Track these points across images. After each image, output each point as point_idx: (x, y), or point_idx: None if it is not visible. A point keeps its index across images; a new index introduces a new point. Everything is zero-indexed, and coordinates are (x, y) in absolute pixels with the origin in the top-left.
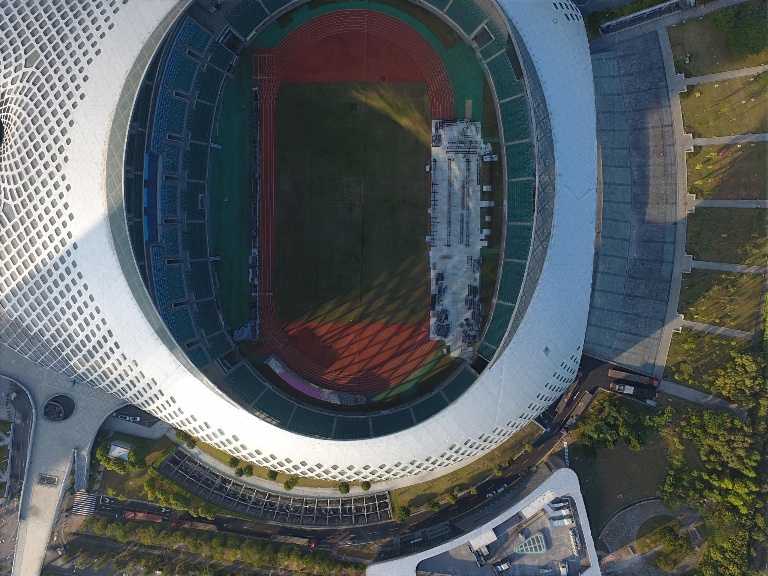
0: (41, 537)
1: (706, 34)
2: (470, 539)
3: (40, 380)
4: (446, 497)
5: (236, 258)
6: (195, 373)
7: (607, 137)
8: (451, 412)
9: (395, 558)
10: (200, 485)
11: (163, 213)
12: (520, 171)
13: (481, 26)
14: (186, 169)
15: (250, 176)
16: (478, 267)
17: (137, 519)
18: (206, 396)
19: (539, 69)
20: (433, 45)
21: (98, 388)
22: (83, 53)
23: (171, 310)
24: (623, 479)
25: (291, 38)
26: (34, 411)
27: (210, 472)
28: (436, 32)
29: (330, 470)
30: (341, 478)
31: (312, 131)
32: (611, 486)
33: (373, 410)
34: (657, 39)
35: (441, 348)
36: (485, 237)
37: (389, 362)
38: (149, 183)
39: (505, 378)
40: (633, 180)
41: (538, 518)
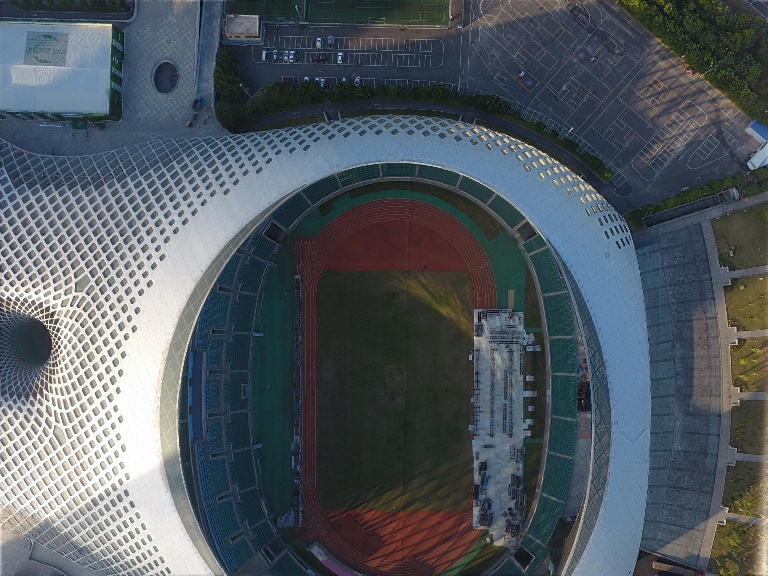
0: None
1: (750, 227)
2: None
3: (84, 569)
4: None
5: (278, 444)
6: None
7: (652, 333)
8: None
9: None
10: None
11: (207, 408)
12: (564, 366)
13: (525, 222)
14: (229, 361)
15: (292, 363)
16: (521, 457)
17: None
18: None
19: (594, 315)
20: (475, 235)
21: None
22: (134, 282)
23: (216, 505)
24: None
25: (333, 226)
26: None
27: None
28: (478, 222)
29: None
30: None
31: (354, 319)
32: None
33: None
34: (701, 231)
35: (484, 537)
36: (528, 427)
37: (432, 550)
38: (194, 381)
39: None
40: (677, 372)
41: None
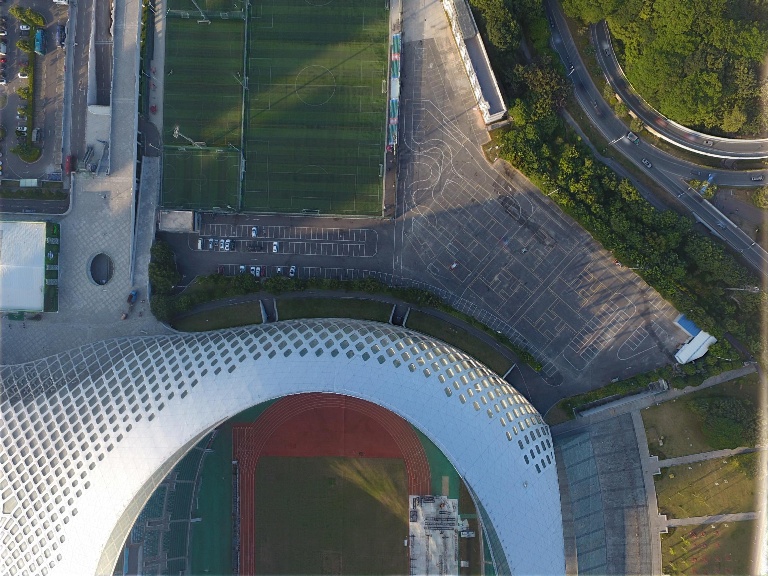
0: None
1: (679, 417)
2: None
3: None
4: None
5: None
6: None
7: (582, 524)
8: None
9: None
10: None
11: None
12: None
13: None
14: (166, 549)
15: (230, 547)
16: None
17: None
18: None
19: (509, 555)
20: None
21: None
22: (60, 509)
23: None
24: None
25: (269, 412)
26: None
27: None
28: None
29: None
30: None
31: (291, 504)
32: None
33: None
34: (631, 421)
35: None
36: None
37: None
38: (129, 575)
39: None
40: (609, 559)
41: None
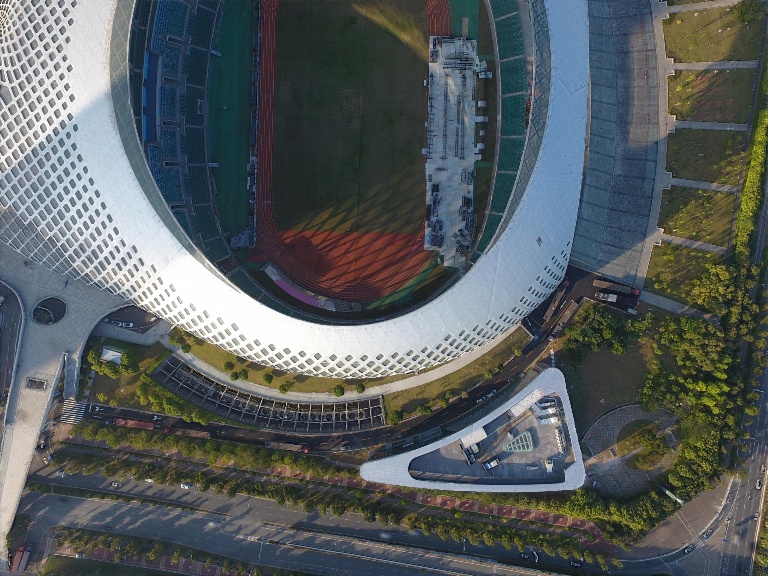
0: (28, 442)
1: None
2: (461, 437)
3: (30, 282)
4: (438, 403)
5: (234, 166)
6: (197, 256)
7: (596, 57)
8: (448, 298)
9: (388, 456)
10: (193, 392)
11: (162, 115)
12: (514, 86)
13: None
14: (186, 73)
15: (250, 85)
16: (472, 180)
17: (128, 427)
18: (207, 280)
19: None
20: None
21: (93, 284)
22: None
23: None
24: (605, 385)
25: None
26: (23, 313)
27: (203, 381)
28: None
29: (328, 361)
30: (338, 372)
31: (312, 43)
32: (594, 391)
33: (368, 318)
34: None
35: (435, 258)
36: (479, 151)
37: (384, 271)
38: (148, 83)
39: (500, 265)
40: (619, 100)
41: (526, 418)
